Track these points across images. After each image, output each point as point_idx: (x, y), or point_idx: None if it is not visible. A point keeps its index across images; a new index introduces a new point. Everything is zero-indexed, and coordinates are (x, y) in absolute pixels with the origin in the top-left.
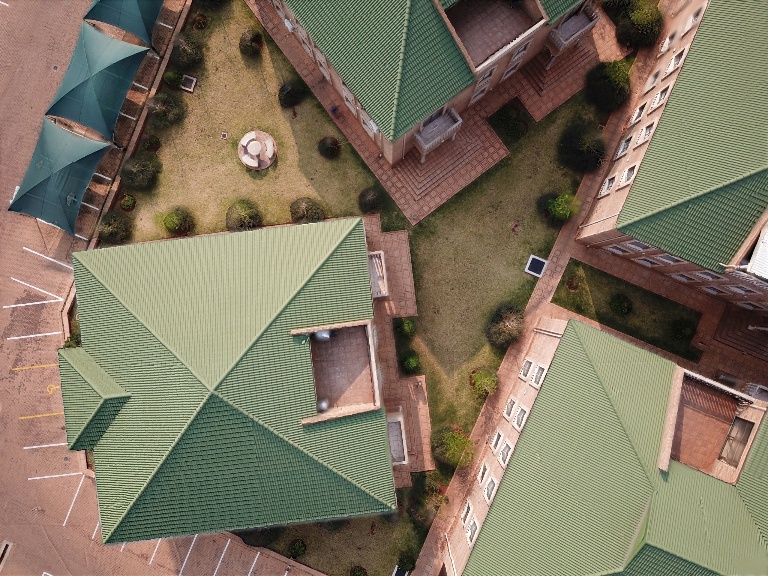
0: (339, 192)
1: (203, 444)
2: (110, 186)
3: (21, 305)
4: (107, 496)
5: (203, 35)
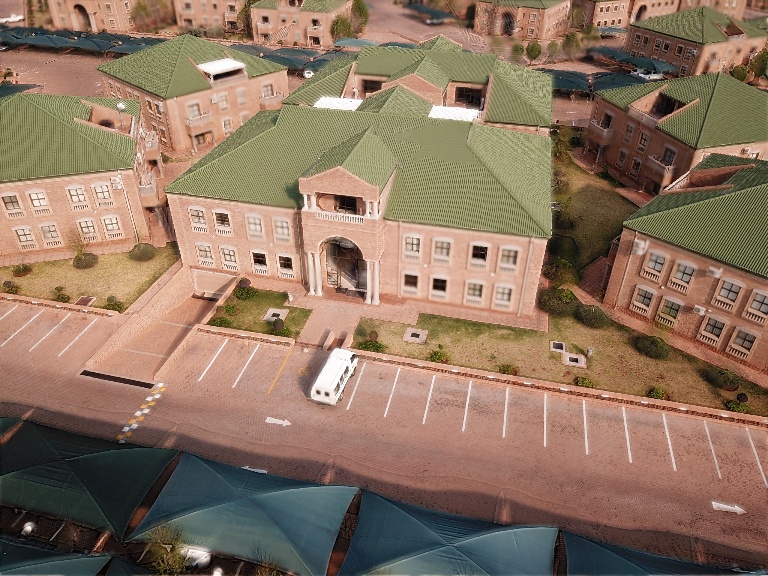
0: None
1: None
2: None
3: None
4: None
5: None
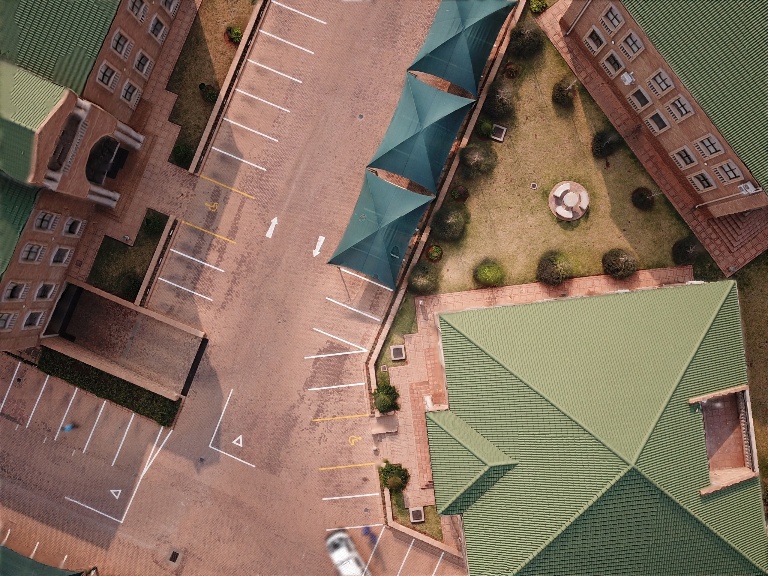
0: (652, 243)
1: (605, 515)
2: (417, 237)
3: (323, 356)
4: (480, 562)
5: (514, 84)
